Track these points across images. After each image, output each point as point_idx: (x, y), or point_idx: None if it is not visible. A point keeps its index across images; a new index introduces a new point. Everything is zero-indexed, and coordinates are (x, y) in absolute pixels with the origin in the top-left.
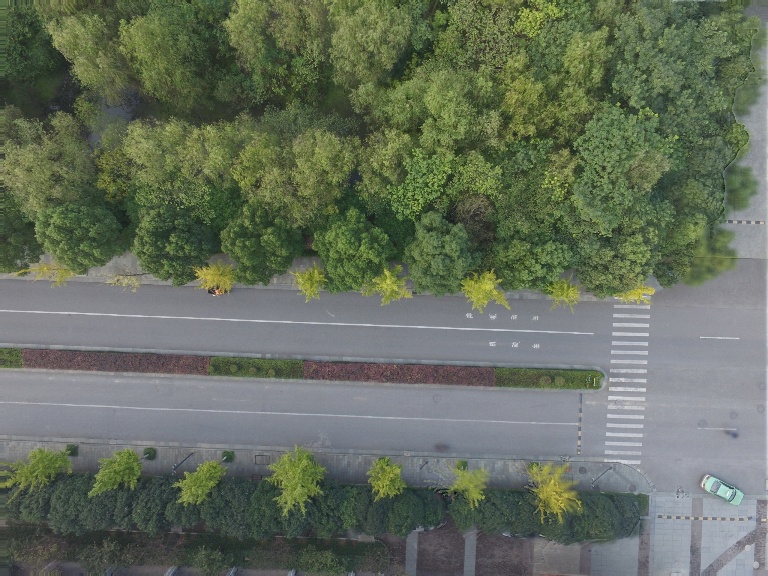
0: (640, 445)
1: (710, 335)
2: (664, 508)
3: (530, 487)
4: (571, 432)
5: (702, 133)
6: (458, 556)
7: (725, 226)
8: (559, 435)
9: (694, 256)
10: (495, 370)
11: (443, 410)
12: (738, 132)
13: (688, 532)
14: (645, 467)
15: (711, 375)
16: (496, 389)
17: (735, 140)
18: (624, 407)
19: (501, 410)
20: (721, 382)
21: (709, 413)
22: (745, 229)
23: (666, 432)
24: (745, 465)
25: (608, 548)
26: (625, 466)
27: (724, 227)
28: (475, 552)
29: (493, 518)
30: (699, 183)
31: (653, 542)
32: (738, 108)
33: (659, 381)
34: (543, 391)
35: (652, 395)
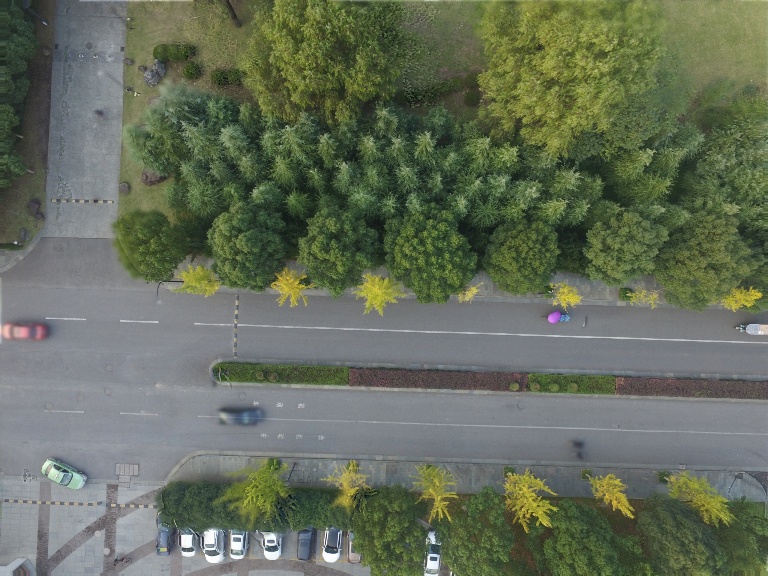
0: None
1: (56, 316)
2: (11, 492)
3: None
4: None
5: None
6: None
7: (72, 205)
8: None
9: (40, 236)
10: None
11: None
12: None
13: (35, 517)
14: None
15: (57, 356)
16: None
17: None
18: None
19: None
20: (67, 364)
21: (55, 395)
22: (93, 208)
23: (12, 414)
24: (94, 449)
25: None
26: None
27: (71, 206)
28: None
29: None
30: None
31: (0, 526)
32: (87, 86)
33: (4, 362)
34: None
35: None
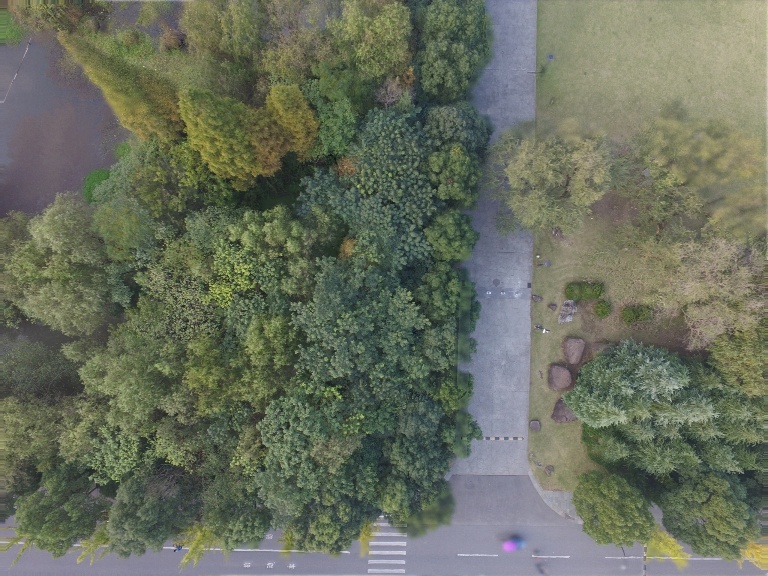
0: None
1: (468, 552)
2: None
3: None
4: None
5: (405, 398)
6: None
7: (482, 443)
8: None
9: (451, 474)
10: None
11: None
12: (445, 394)
13: None
14: None
15: None
16: None
17: (444, 400)
18: None
19: None
20: None
21: None
22: (503, 445)
23: None
24: None
25: None
26: None
27: (481, 444)
28: None
29: None
30: (403, 449)
31: None
32: (495, 323)
33: None
34: None
35: None
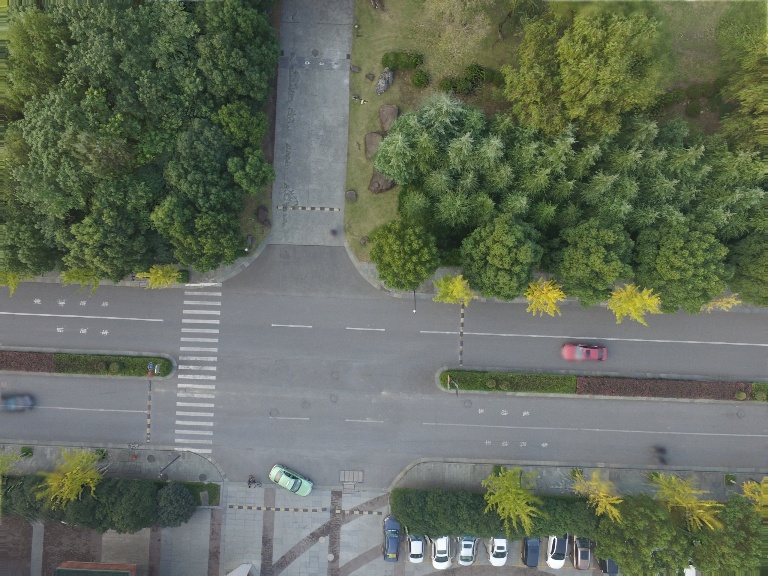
0: (211, 434)
1: (282, 323)
2: (236, 498)
3: (69, 474)
4: (140, 420)
5: (181, 115)
6: (25, 544)
7: (298, 213)
8: (128, 423)
9: (266, 243)
10: (54, 356)
11: (10, 396)
12: (224, 114)
13: (260, 523)
14: (216, 456)
15: (283, 363)
16: (60, 375)
17: (224, 122)
18: (194, 395)
19: (69, 397)
20: (293, 371)
21: (281, 402)
22: (319, 216)
23: (237, 421)
24: (319, 455)
25: (178, 538)
26: (195, 455)
27: (297, 214)
28: (43, 540)
29: (18, 504)
30: (177, 165)
31: (224, 532)
32: (313, 93)
33: (229, 369)
34: (110, 378)
35: (222, 383)
